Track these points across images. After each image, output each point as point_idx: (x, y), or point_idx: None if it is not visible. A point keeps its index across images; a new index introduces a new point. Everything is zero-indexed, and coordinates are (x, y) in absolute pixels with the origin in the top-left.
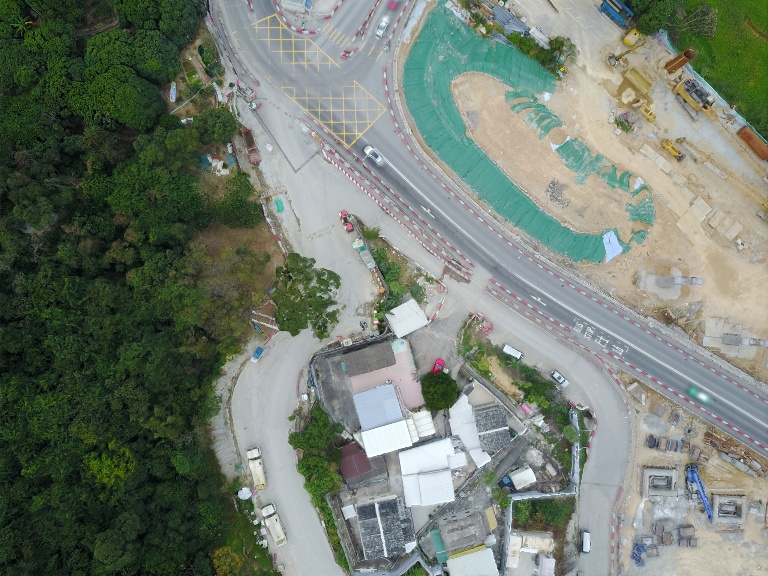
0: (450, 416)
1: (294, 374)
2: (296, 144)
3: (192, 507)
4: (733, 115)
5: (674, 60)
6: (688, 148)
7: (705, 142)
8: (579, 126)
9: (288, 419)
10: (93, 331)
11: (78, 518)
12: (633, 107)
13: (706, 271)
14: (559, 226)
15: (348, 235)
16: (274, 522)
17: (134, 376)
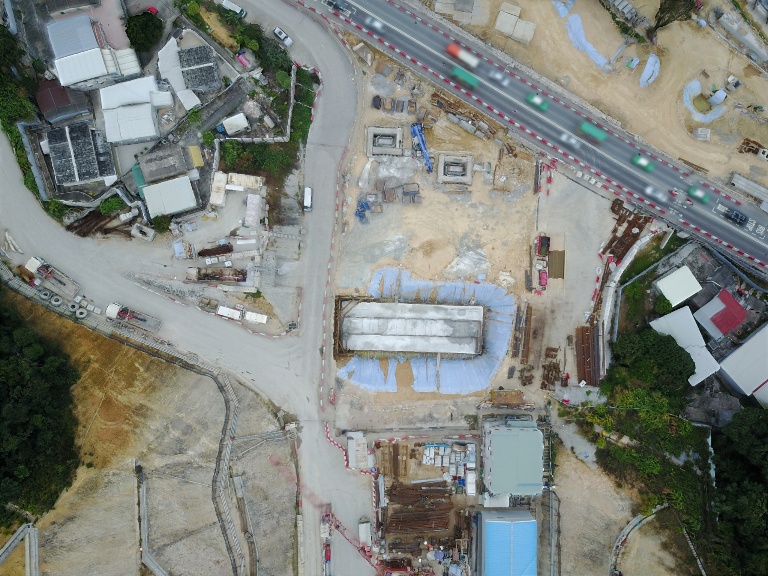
0: None
1: None
2: None
3: None
4: None
5: None
6: None
7: None
8: None
9: None
10: None
11: None
12: None
13: None
14: None
15: None
16: None
17: None
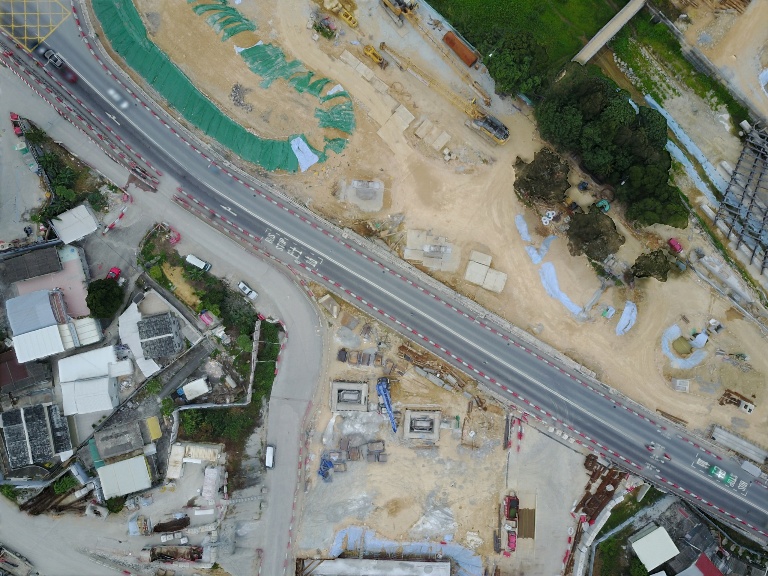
0: (119, 324)
1: None
2: None
3: None
4: (439, 21)
5: None
6: (390, 54)
7: (412, 49)
8: (276, 31)
9: None
10: None
11: None
12: (333, 12)
13: (408, 181)
14: (244, 132)
15: (18, 139)
16: None
17: None
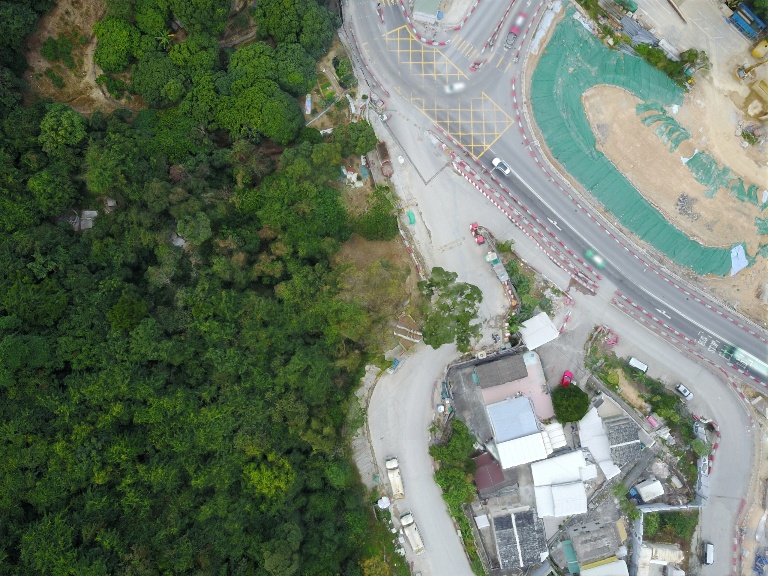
0: (580, 428)
1: (428, 385)
2: (426, 156)
3: (341, 516)
4: None
5: None
6: None
7: None
8: (706, 139)
9: (429, 431)
10: (250, 344)
11: (244, 528)
12: (760, 120)
13: None
14: (687, 240)
15: (479, 247)
16: (413, 531)
17: (293, 389)
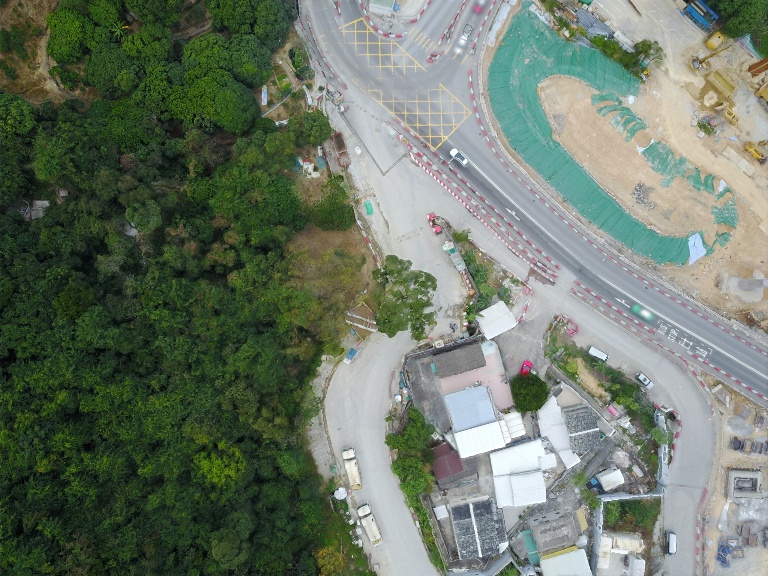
0: (539, 417)
1: (386, 375)
2: (383, 147)
3: (294, 507)
4: None
5: (759, 63)
6: None
7: None
8: (662, 129)
9: (385, 420)
10: (200, 332)
11: (192, 517)
12: (716, 110)
13: None
14: (645, 228)
15: (437, 237)
16: (370, 522)
17: (243, 377)
